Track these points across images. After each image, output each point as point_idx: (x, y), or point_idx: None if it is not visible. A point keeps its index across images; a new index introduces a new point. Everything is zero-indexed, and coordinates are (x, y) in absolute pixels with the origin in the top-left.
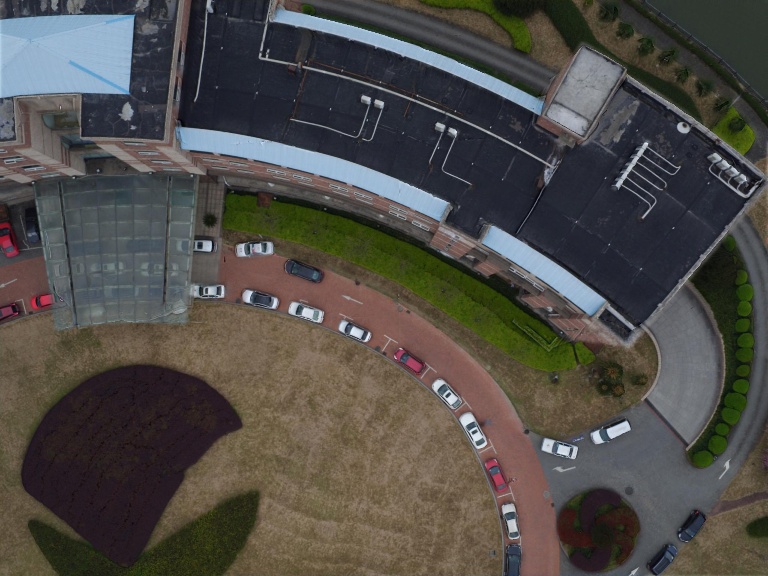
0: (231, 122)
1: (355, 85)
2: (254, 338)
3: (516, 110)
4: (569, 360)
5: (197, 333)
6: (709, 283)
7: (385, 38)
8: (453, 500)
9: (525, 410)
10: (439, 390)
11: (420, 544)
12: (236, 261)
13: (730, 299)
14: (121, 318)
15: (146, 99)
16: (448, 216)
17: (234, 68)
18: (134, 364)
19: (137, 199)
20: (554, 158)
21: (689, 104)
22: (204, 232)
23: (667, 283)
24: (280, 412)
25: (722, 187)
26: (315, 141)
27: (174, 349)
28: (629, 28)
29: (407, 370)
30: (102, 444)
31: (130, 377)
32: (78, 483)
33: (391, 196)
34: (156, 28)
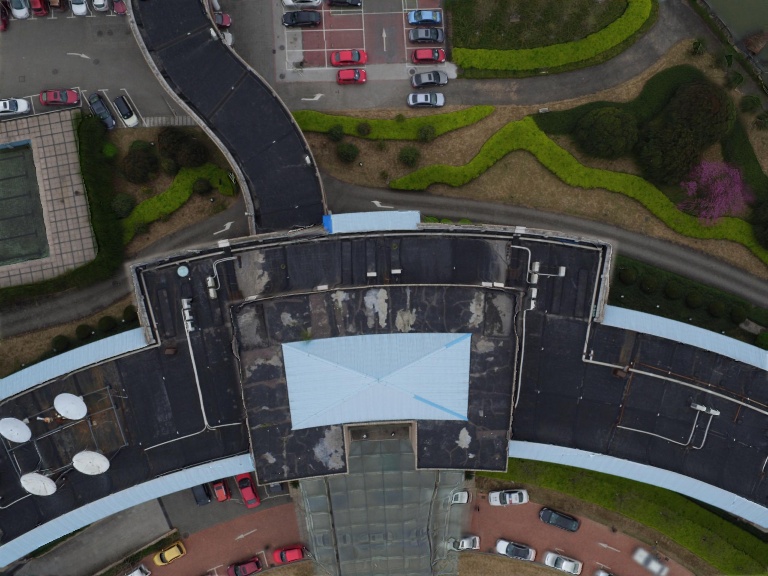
0: (553, 428)
1: (682, 387)
2: None
3: None
4: None
5: None
6: None
7: (713, 336)
8: None
9: None
10: None
11: None
12: (490, 510)
13: None
14: None
15: (484, 424)
16: None
17: (555, 370)
18: None
19: (406, 465)
20: None
21: None
22: (463, 486)
23: None
24: None
25: None
26: (642, 448)
27: None
28: None
29: None
30: None
31: None
32: None
33: (721, 505)
34: (491, 345)
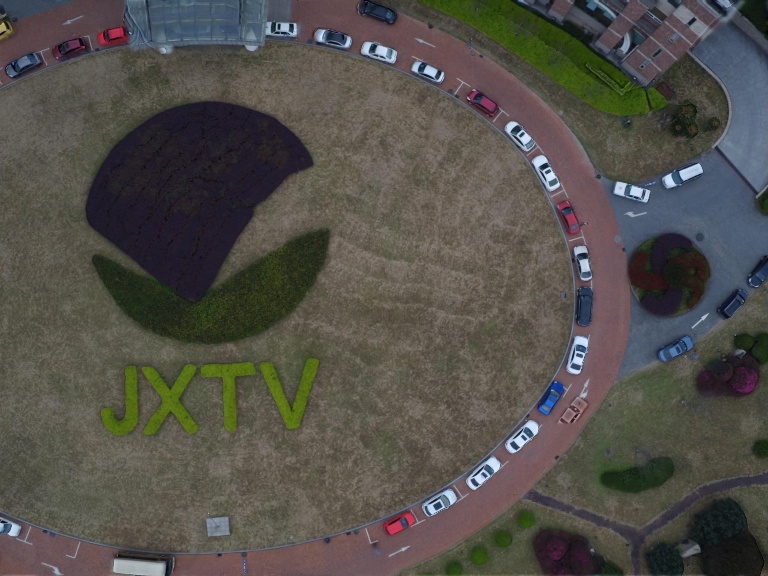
0: None
1: None
2: (325, 78)
3: None
4: (642, 104)
5: (268, 72)
6: None
7: None
8: (525, 243)
9: (597, 155)
10: (512, 131)
11: (491, 286)
12: (308, 0)
13: None
14: (196, 37)
15: None
16: None
17: None
18: (203, 101)
19: None
20: None
21: None
22: None
23: None
24: (351, 152)
25: None
26: None
27: (244, 87)
28: None
29: (479, 113)
30: (170, 177)
31: (200, 112)
32: (145, 216)
33: None
34: None
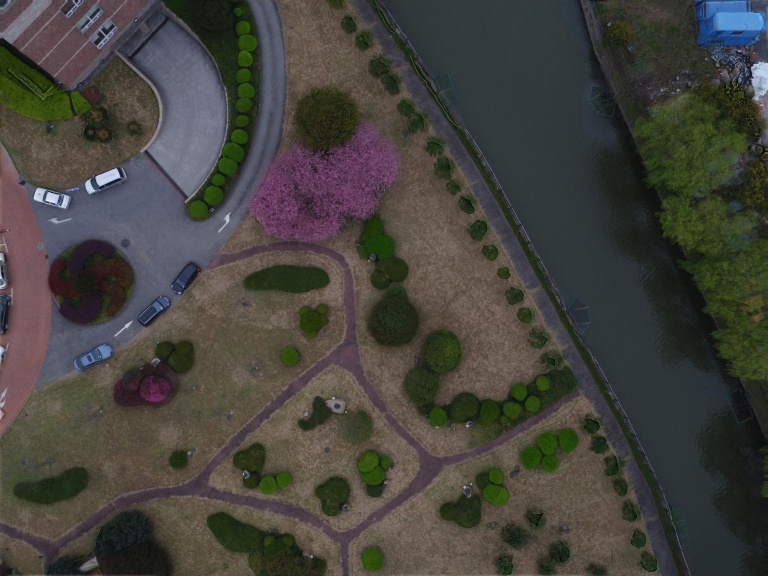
0: None
1: None
2: None
3: None
4: (63, 109)
5: None
6: (207, 32)
7: None
8: None
9: (22, 161)
10: None
11: None
12: None
13: (232, 50)
14: None
15: None
16: None
17: None
18: None
19: None
20: None
21: None
22: None
23: None
24: None
25: None
26: None
27: None
28: None
29: None
30: None
31: None
32: None
33: None
34: None
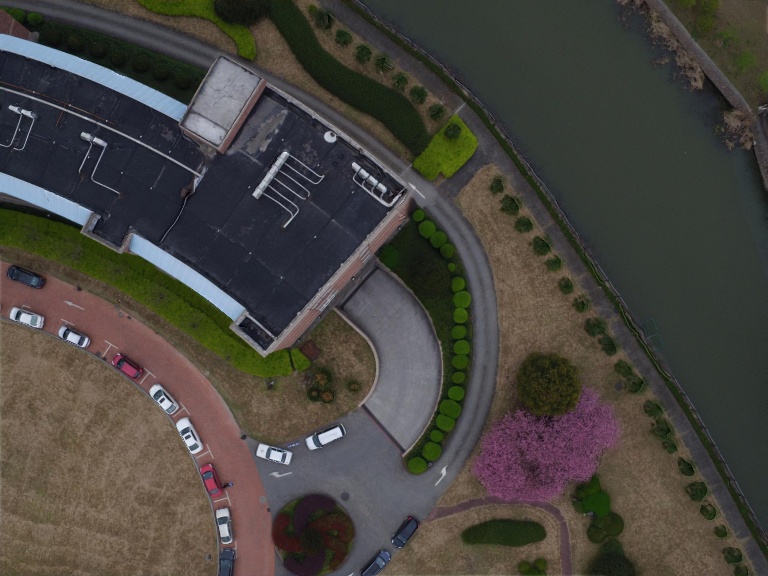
0: None
1: (10, 95)
2: None
3: (165, 119)
4: (284, 366)
5: None
6: (424, 290)
7: (40, 48)
8: (169, 504)
9: (242, 415)
10: (155, 395)
11: (136, 548)
12: None
13: (447, 306)
14: None
15: None
16: (96, 225)
17: None
18: None
19: None
20: (204, 167)
21: (410, 111)
22: None
23: (308, 292)
24: (0, 416)
25: (367, 196)
26: None
27: None
28: (345, 36)
29: (126, 375)
30: None
31: None
32: None
33: (42, 205)
34: None
